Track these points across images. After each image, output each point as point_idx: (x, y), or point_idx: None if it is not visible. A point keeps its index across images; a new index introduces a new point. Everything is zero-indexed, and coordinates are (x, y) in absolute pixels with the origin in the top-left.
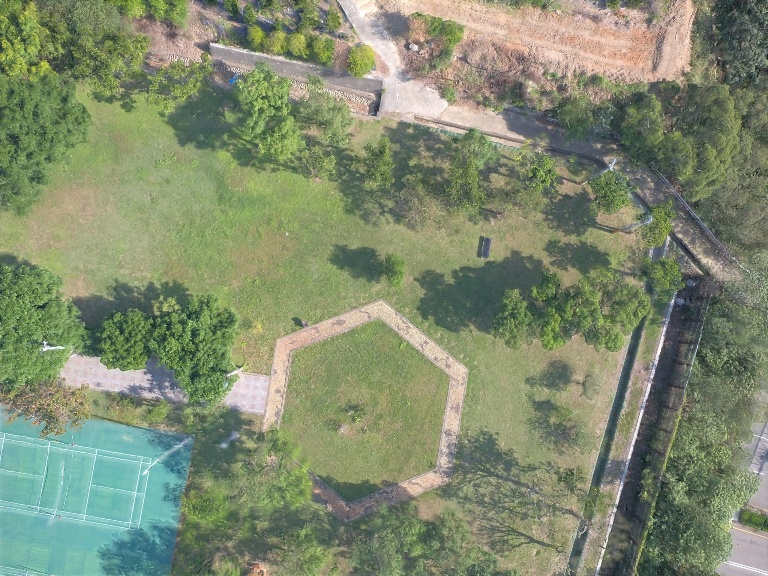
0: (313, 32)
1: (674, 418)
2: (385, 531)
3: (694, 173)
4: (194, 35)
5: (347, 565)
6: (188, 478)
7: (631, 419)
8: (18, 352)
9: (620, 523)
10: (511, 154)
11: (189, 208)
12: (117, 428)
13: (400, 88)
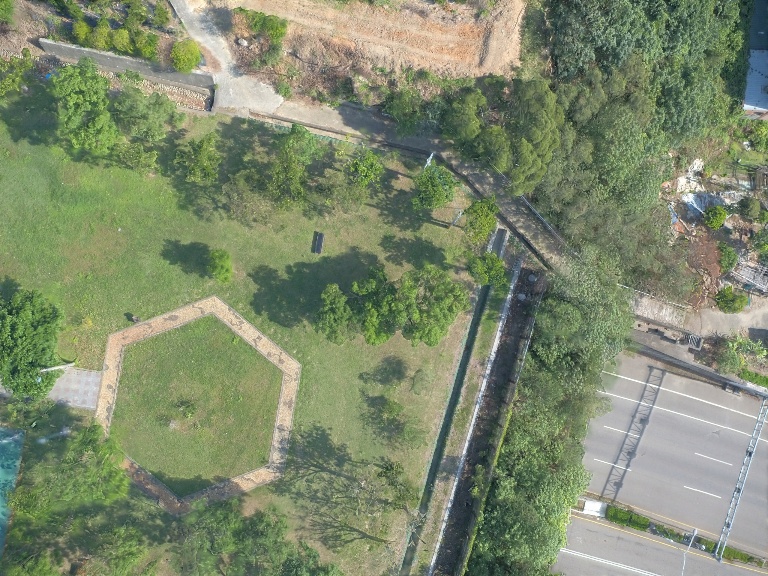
0: (143, 27)
1: (505, 413)
2: (197, 526)
3: (513, 167)
4: (26, 31)
5: (179, 560)
6: (19, 473)
7: (467, 414)
8: None
9: (460, 518)
10: (346, 149)
11: (22, 204)
12: None
13: (233, 83)
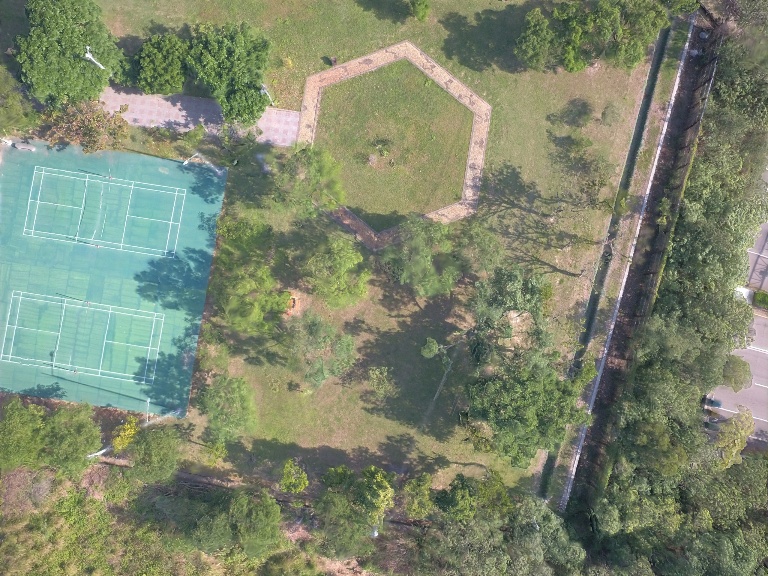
0: None
1: (691, 147)
2: (415, 228)
3: None
4: None
5: (376, 293)
6: (222, 209)
7: (649, 156)
8: (61, 64)
9: (639, 264)
10: None
11: None
12: (153, 162)
13: None
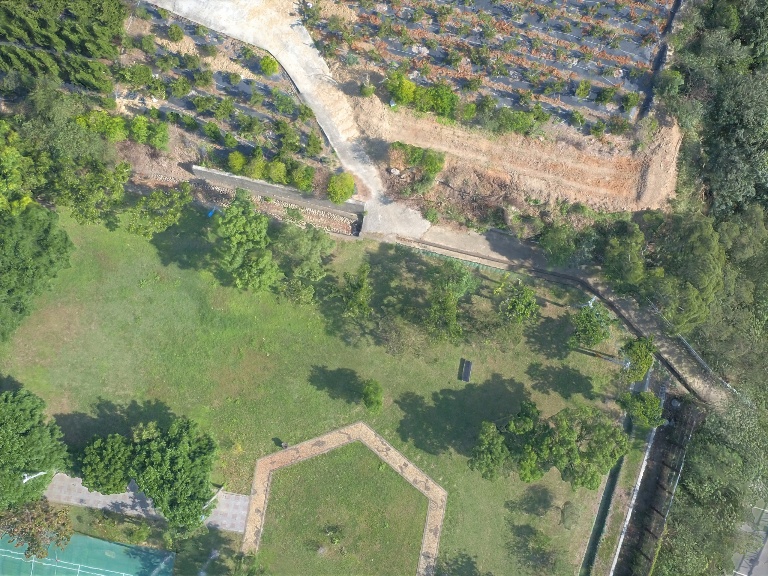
0: (295, 156)
1: (654, 547)
2: None
3: (676, 309)
4: (178, 156)
5: None
6: None
7: (611, 544)
8: (0, 480)
9: None
10: (494, 275)
11: (172, 328)
12: (99, 544)
13: (382, 210)
